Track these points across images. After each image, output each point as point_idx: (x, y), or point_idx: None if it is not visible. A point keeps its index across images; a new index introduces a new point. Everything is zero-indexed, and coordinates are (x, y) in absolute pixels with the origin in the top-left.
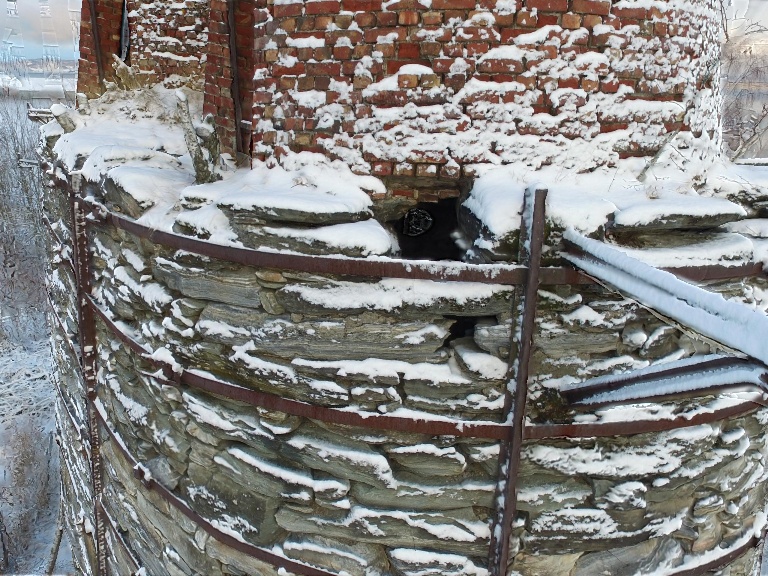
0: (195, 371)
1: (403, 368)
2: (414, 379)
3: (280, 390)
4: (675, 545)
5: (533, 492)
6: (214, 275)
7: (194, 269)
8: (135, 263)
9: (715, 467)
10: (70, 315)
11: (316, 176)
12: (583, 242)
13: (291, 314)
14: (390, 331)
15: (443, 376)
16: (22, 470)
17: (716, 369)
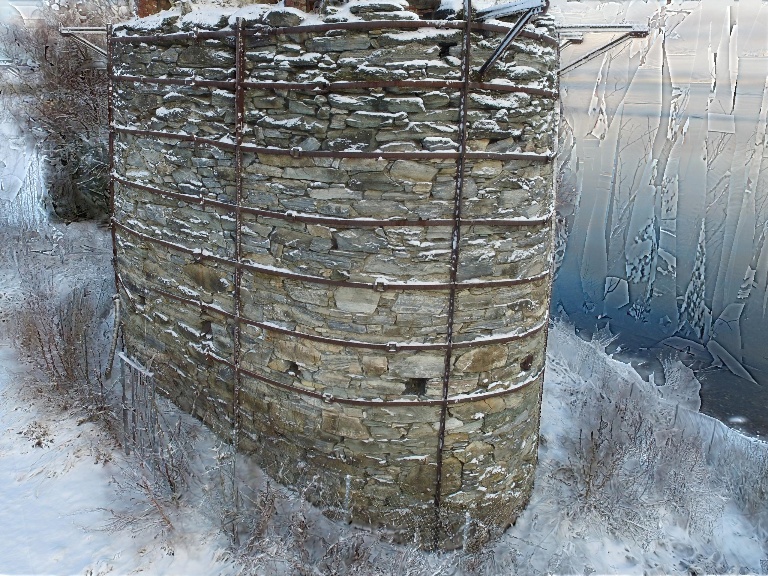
0: (337, 82)
1: (427, 62)
2: (431, 66)
3: (380, 79)
4: (519, 146)
5: (472, 112)
6: (349, 36)
7: (339, 36)
8: (295, 47)
9: (530, 113)
10: (194, 120)
11: (382, 0)
12: (484, 10)
13: (384, 46)
14: (422, 48)
15: (441, 64)
16: (26, 345)
17: (524, 18)
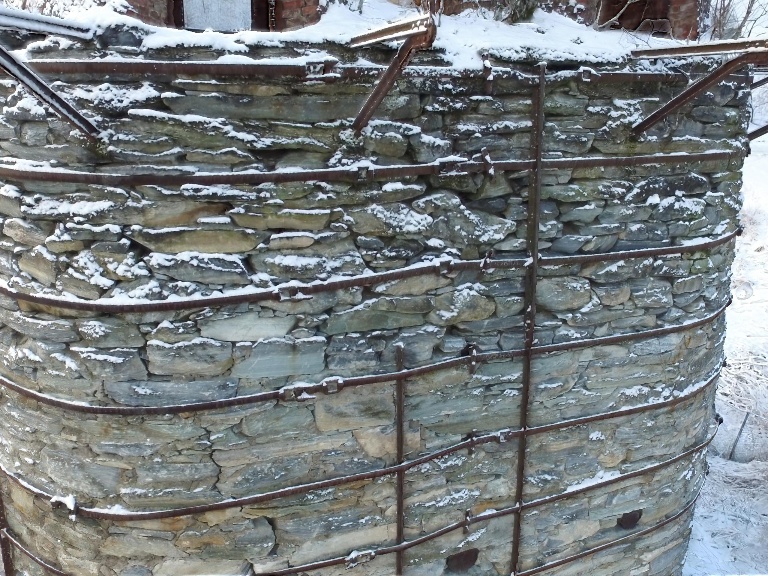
0: None
1: None
2: None
3: None
4: None
5: None
6: None
7: None
8: None
9: None
10: None
11: None
12: None
13: None
14: None
15: None
16: None
17: None
